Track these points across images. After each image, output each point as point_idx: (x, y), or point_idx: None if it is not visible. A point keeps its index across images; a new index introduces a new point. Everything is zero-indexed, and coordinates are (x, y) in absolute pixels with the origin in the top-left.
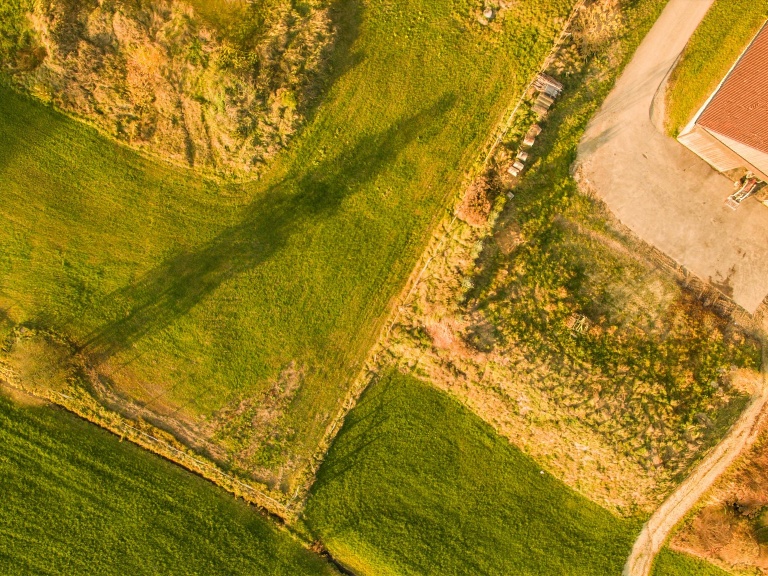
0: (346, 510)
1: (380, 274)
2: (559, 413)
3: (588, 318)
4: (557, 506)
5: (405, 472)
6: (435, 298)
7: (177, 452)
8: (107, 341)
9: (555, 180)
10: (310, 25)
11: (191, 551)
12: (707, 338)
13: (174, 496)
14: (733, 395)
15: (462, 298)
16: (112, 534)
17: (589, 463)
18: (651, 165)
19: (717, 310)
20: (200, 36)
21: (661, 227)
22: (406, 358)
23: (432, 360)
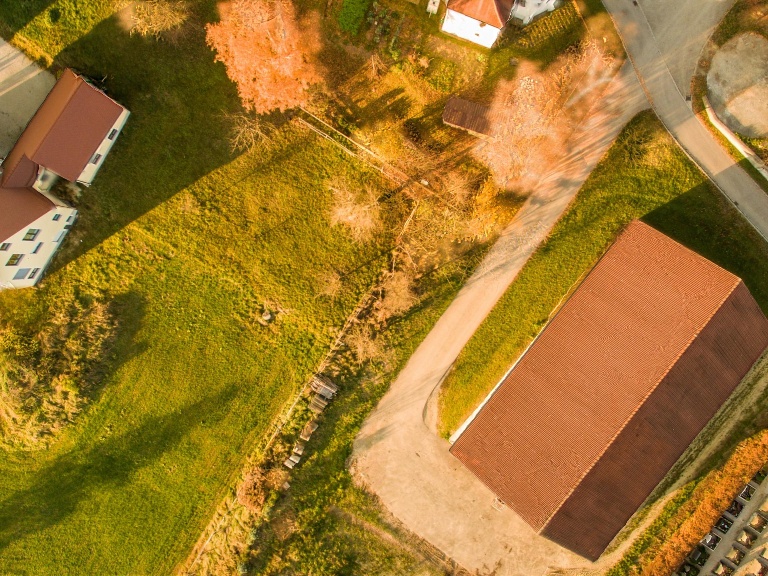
0: None
1: (166, 542)
2: None
3: None
4: None
5: None
6: (215, 573)
7: None
8: None
9: (331, 472)
10: (92, 318)
11: None
12: None
13: None
14: None
15: None
16: None
17: None
18: (424, 463)
19: None
20: None
21: (431, 521)
22: None
23: None
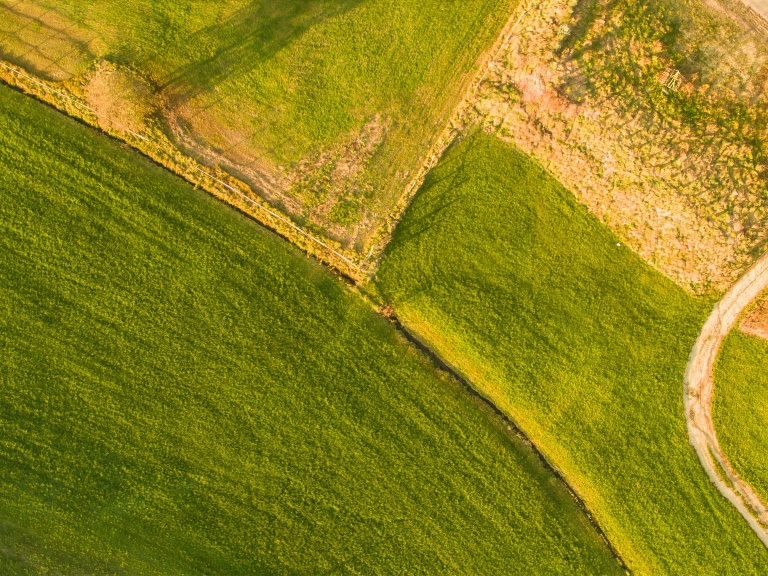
0: (419, 274)
1: (472, 28)
2: (644, 174)
3: (681, 74)
4: (631, 281)
5: (481, 237)
6: (528, 50)
7: (252, 204)
8: (189, 82)
9: None
10: None
11: (259, 308)
12: None
13: (245, 250)
14: None
15: (558, 45)
16: (179, 285)
17: (669, 231)
18: None
19: None
20: None
21: None
22: (492, 116)
23: (519, 117)
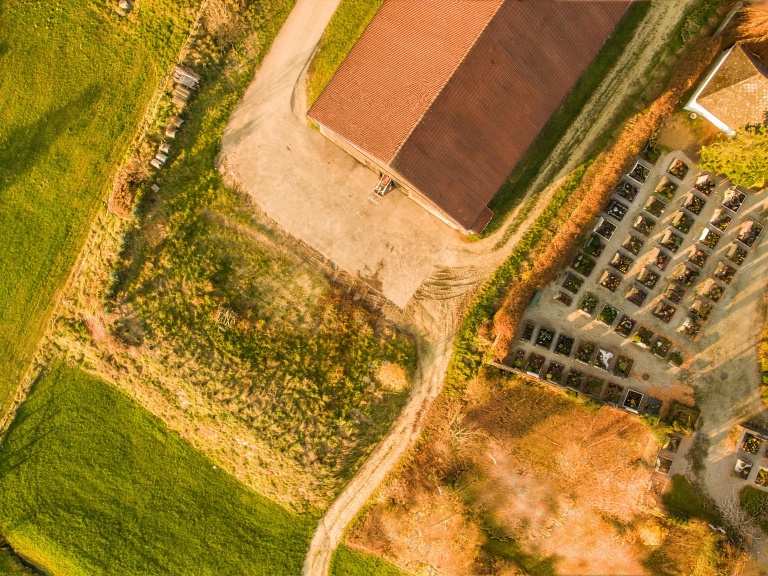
0: (23, 503)
1: (43, 267)
2: (214, 407)
3: (235, 312)
4: (232, 501)
5: (80, 466)
6: (91, 291)
7: None
8: None
9: (201, 172)
10: None
11: None
12: (358, 333)
13: None
14: (386, 391)
15: (107, 291)
16: None
17: (252, 458)
18: (295, 157)
19: (367, 304)
20: None
21: (307, 220)
22: (71, 351)
23: (94, 353)
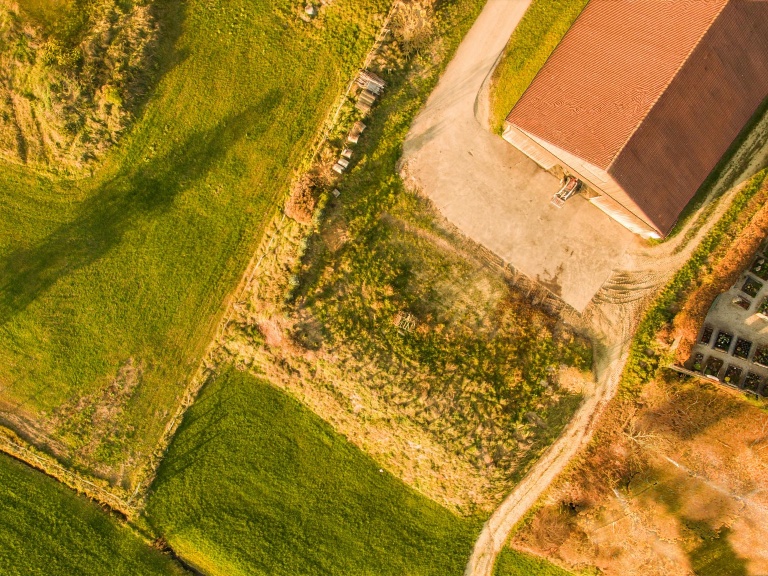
0: (187, 507)
1: (215, 271)
2: (390, 411)
3: (415, 316)
4: (397, 504)
5: (245, 469)
6: (266, 295)
7: (19, 448)
8: None
9: (381, 177)
10: (132, 22)
11: (34, 547)
12: (536, 337)
13: (17, 492)
14: (563, 394)
15: (288, 295)
16: None
17: (423, 462)
18: (477, 162)
19: (546, 308)
20: (26, 33)
21: (488, 225)
22: (242, 355)
23: (266, 357)
